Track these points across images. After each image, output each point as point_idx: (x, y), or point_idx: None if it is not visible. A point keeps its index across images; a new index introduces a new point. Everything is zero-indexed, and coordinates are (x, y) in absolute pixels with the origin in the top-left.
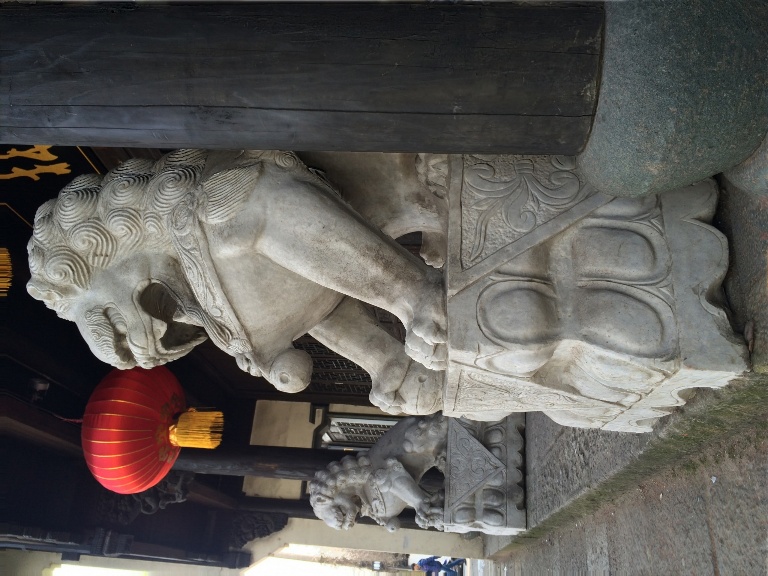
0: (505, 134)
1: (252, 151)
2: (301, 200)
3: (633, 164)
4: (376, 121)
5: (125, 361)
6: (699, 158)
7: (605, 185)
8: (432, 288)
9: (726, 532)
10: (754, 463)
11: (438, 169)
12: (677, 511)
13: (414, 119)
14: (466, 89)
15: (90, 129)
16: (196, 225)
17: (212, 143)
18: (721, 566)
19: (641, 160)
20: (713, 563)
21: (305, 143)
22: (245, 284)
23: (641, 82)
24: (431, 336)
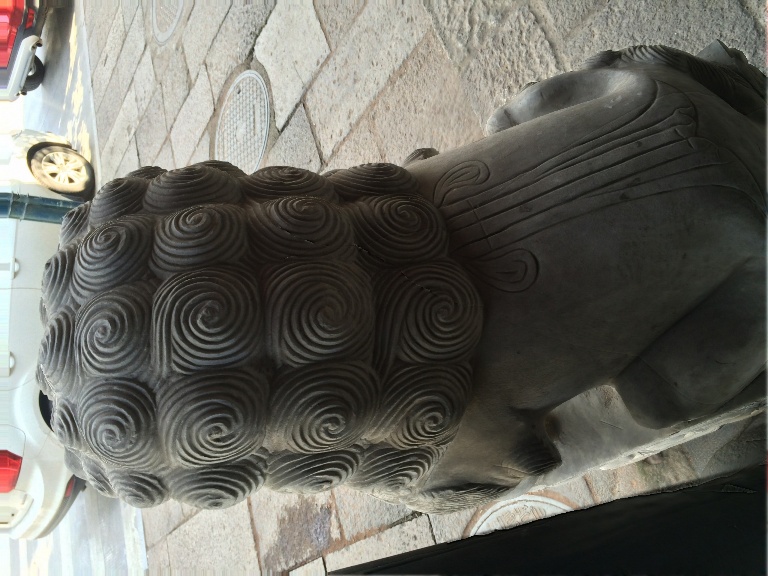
0: None
1: None
2: None
3: None
4: None
5: None
6: None
7: None
8: None
9: None
10: None
11: None
12: None
13: None
14: None
15: None
16: None
17: None
18: None
19: None
20: None
21: None
22: None
23: None
24: None
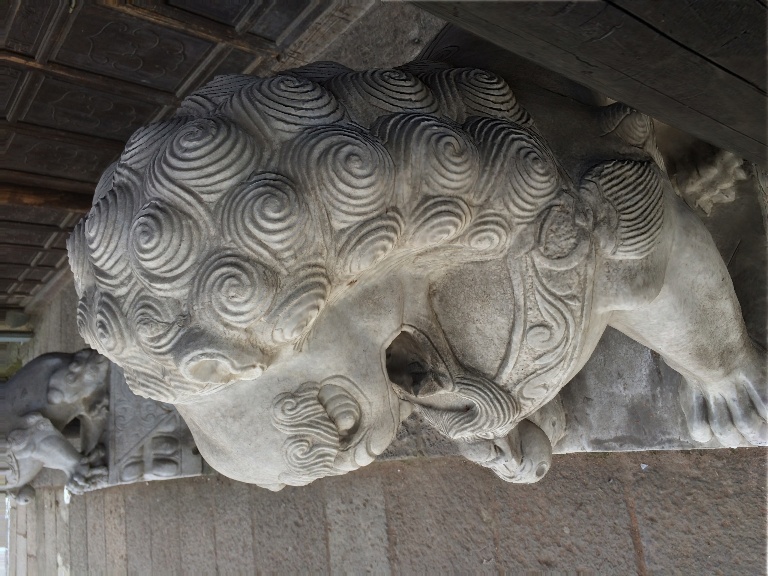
0: None
1: (634, 134)
2: (708, 235)
3: None
4: None
5: None
6: None
7: None
8: None
9: (663, 513)
10: (726, 463)
11: (726, 196)
12: (560, 485)
13: None
14: None
15: (743, 85)
16: (593, 257)
17: None
18: (648, 540)
19: None
20: (632, 536)
21: None
22: (592, 350)
23: None
24: None
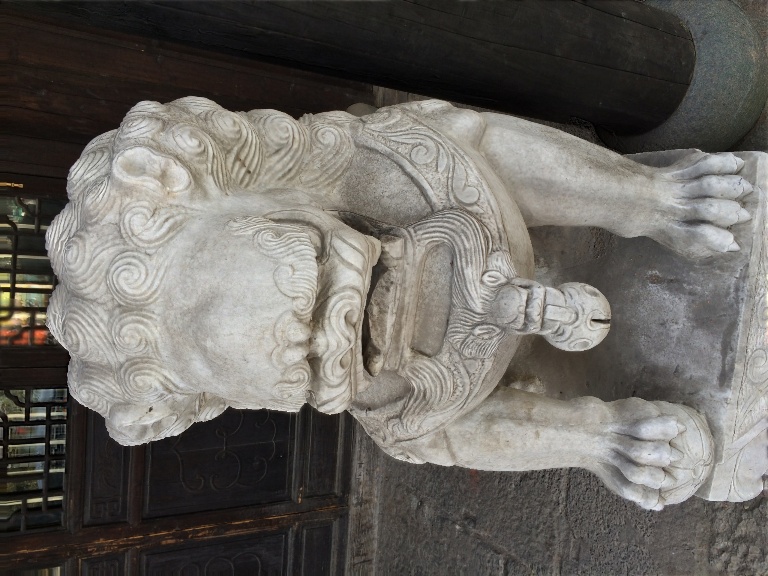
0: (653, 46)
1: None
2: None
3: (742, 50)
4: (577, 10)
5: (311, 311)
6: (764, 60)
7: (723, 92)
8: (675, 161)
9: None
10: None
11: None
12: None
13: (601, 15)
14: (623, 4)
15: None
16: (407, 111)
17: (441, 7)
18: None
19: (745, 46)
20: None
21: (522, 26)
22: (489, 170)
23: (717, 1)
24: (731, 153)
